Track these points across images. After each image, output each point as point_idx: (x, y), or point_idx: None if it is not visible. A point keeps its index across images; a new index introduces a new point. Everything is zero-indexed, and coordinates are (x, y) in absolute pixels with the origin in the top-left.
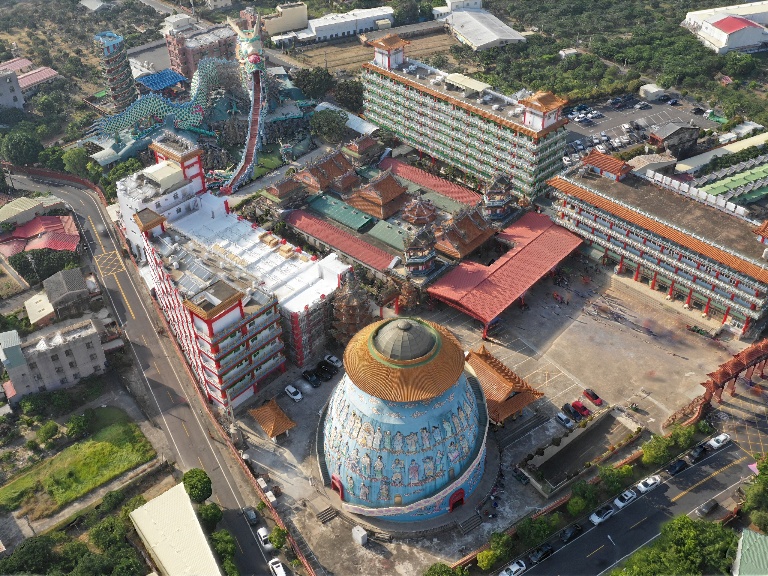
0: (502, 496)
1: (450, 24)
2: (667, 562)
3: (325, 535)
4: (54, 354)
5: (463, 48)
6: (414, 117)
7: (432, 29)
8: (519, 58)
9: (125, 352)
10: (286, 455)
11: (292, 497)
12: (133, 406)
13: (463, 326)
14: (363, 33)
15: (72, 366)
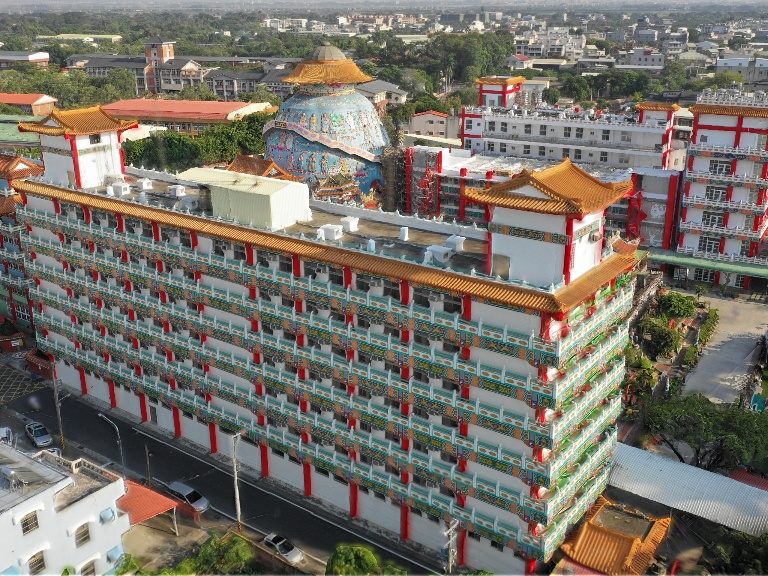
0: None
1: None
2: None
3: None
4: None
5: None
6: None
7: None
8: None
9: None
10: None
11: None
12: None
13: None
14: None
15: None
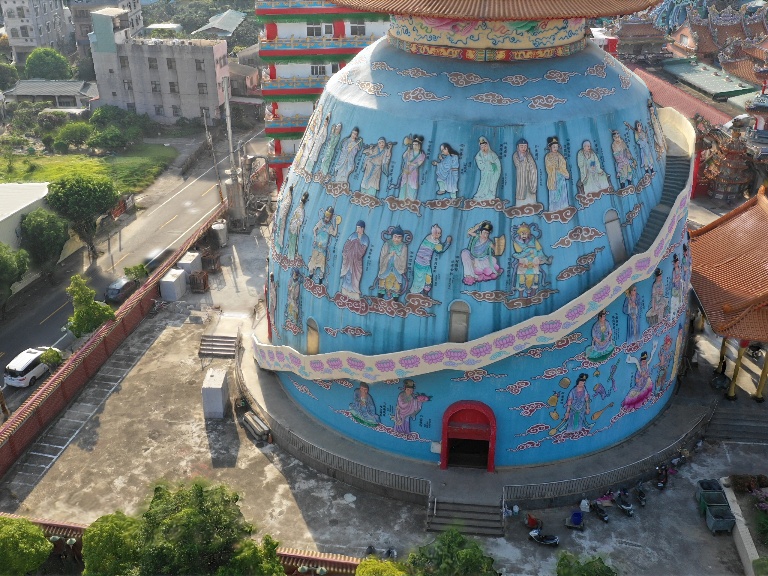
0: (617, 518)
1: None
2: None
3: (177, 369)
4: (153, 56)
5: None
6: None
7: None
8: None
9: (260, 119)
10: None
11: (212, 303)
12: None
13: None
14: None
15: (174, 91)
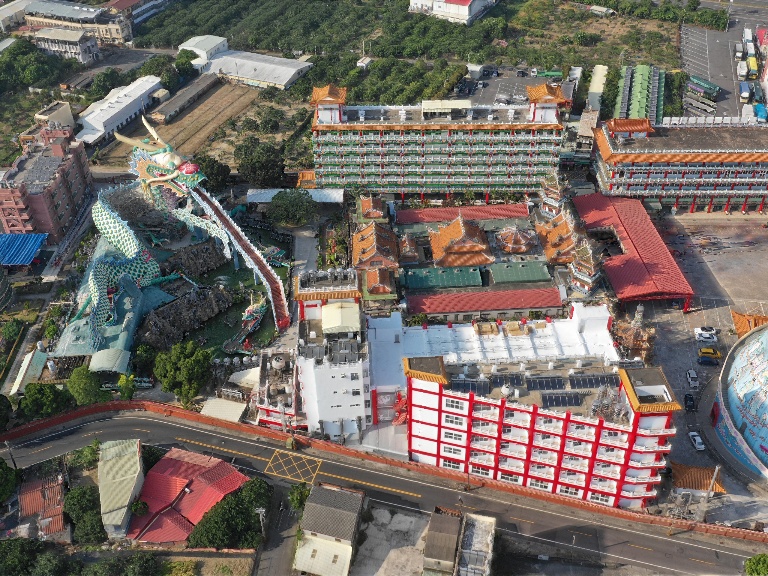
0: None
1: (225, 73)
2: None
3: None
4: None
5: (271, 91)
6: (396, 161)
7: (210, 84)
8: (331, 82)
9: None
10: (734, 499)
11: None
12: (569, 568)
13: (657, 313)
14: (154, 111)
15: None
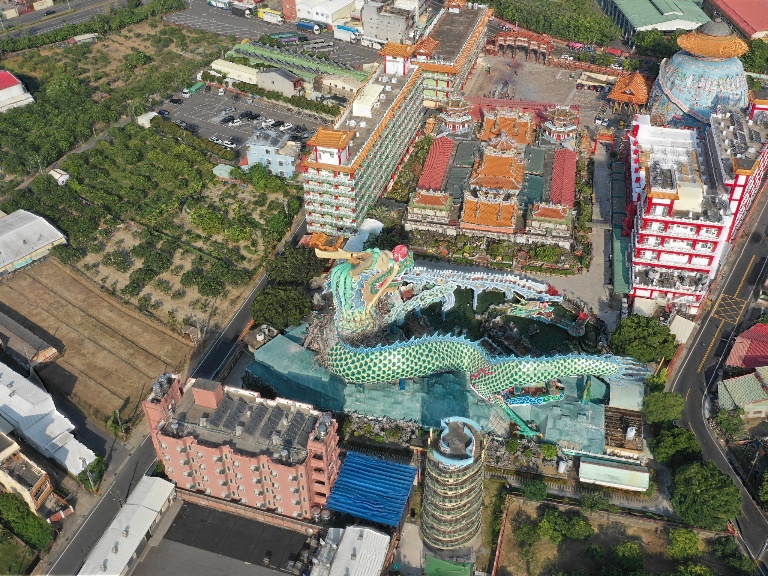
0: None
1: None
2: (678, 33)
3: None
4: None
5: None
6: None
7: None
8: None
9: None
10: None
11: None
12: None
13: None
14: (36, 353)
15: None
